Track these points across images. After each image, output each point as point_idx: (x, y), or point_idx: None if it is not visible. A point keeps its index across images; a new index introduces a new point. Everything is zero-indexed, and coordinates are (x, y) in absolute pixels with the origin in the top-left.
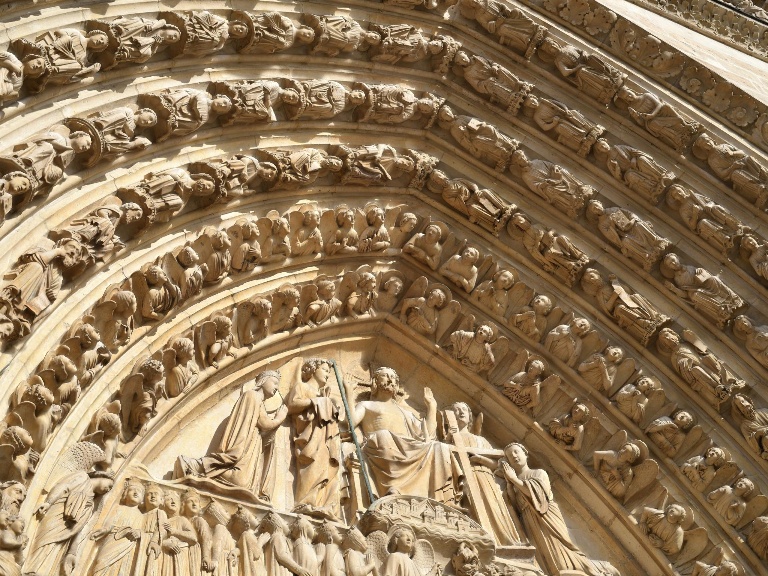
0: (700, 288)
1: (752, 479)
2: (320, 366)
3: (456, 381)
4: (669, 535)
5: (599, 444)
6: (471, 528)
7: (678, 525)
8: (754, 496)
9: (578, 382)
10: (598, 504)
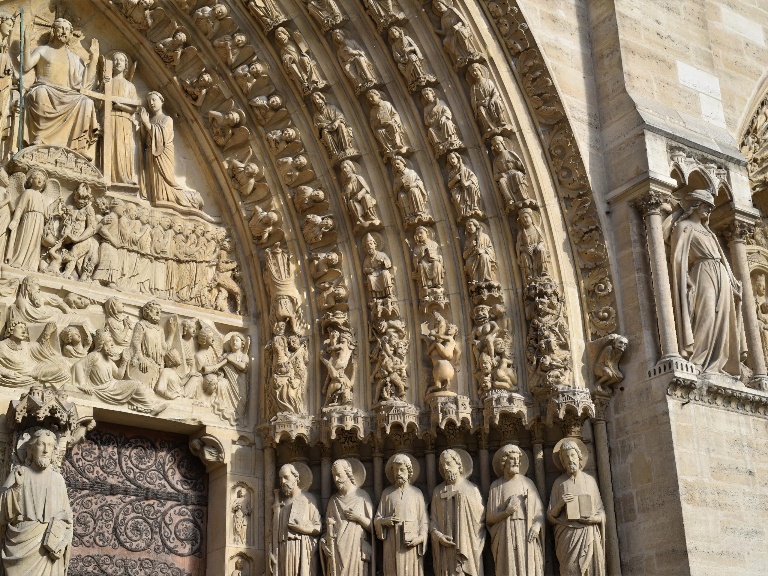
0: (314, 0)
1: (308, 156)
2: (5, 21)
3: (123, 31)
4: (244, 183)
5: (217, 103)
6: (92, 172)
7: (251, 178)
8: (305, 169)
9: (212, 52)
10: (207, 147)
